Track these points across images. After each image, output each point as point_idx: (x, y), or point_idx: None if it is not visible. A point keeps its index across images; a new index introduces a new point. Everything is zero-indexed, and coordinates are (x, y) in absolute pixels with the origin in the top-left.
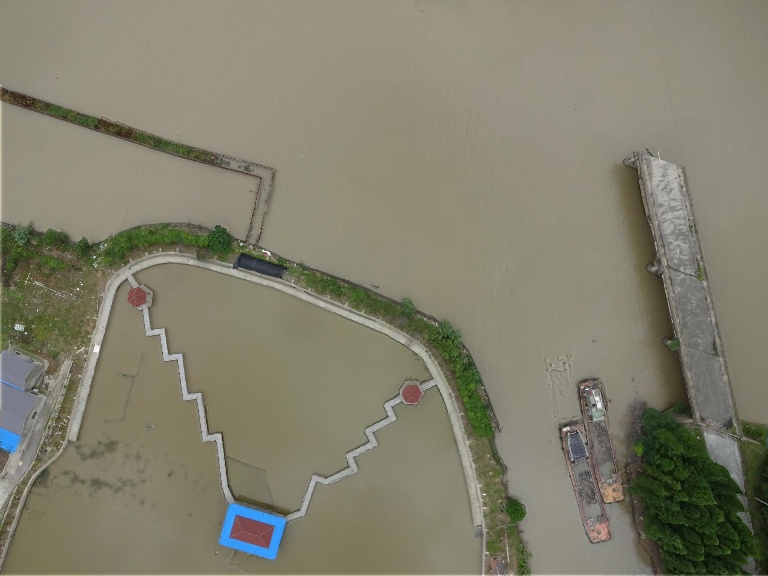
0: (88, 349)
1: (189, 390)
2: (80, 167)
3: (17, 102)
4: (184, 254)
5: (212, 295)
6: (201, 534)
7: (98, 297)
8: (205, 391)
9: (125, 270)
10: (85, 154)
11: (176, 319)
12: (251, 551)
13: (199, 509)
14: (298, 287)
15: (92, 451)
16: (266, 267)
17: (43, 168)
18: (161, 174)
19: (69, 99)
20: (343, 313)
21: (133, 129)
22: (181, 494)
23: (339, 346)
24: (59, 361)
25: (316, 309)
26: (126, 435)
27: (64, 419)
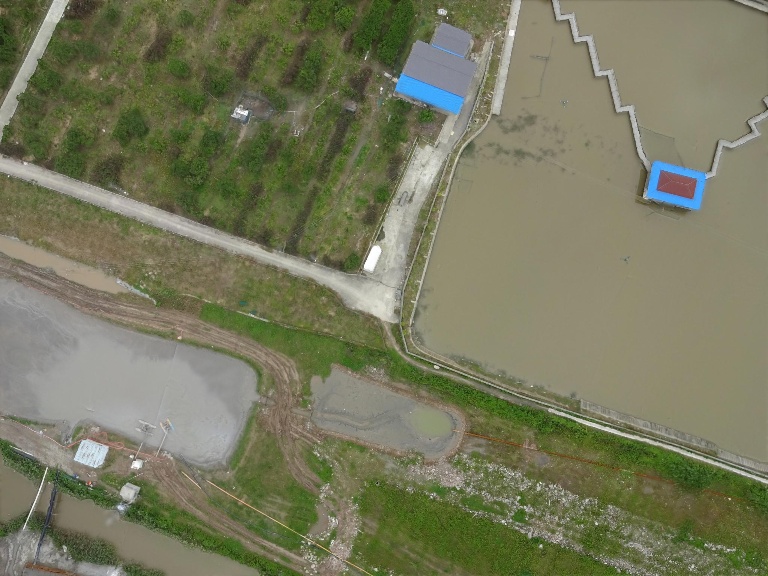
0: (504, 32)
1: None
2: None
3: None
4: None
5: None
6: None
7: None
8: None
9: None
10: None
11: (580, 7)
12: (677, 202)
13: (616, 174)
14: None
15: (513, 125)
16: None
17: None
18: None
19: None
20: None
21: None
22: (598, 162)
23: (731, 28)
24: (481, 42)
25: None
26: (543, 110)
27: (488, 94)
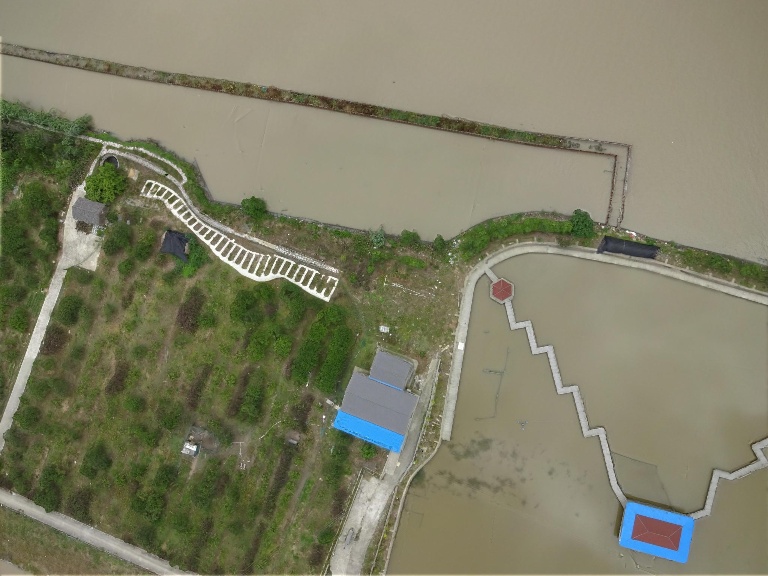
0: (453, 347)
1: (563, 383)
2: (423, 167)
3: (358, 111)
4: (543, 243)
5: (575, 283)
6: (596, 535)
7: (458, 294)
8: (579, 384)
9: (482, 264)
10: (426, 154)
11: (539, 310)
12: (657, 554)
13: (586, 509)
14: (673, 266)
15: (466, 450)
16: (638, 248)
17: (386, 172)
18: (506, 164)
19: (407, 102)
20: (729, 291)
21: (475, 123)
22: (564, 493)
23: (727, 327)
24: (426, 360)
25: (695, 289)
26: (499, 433)
27: (436, 418)
